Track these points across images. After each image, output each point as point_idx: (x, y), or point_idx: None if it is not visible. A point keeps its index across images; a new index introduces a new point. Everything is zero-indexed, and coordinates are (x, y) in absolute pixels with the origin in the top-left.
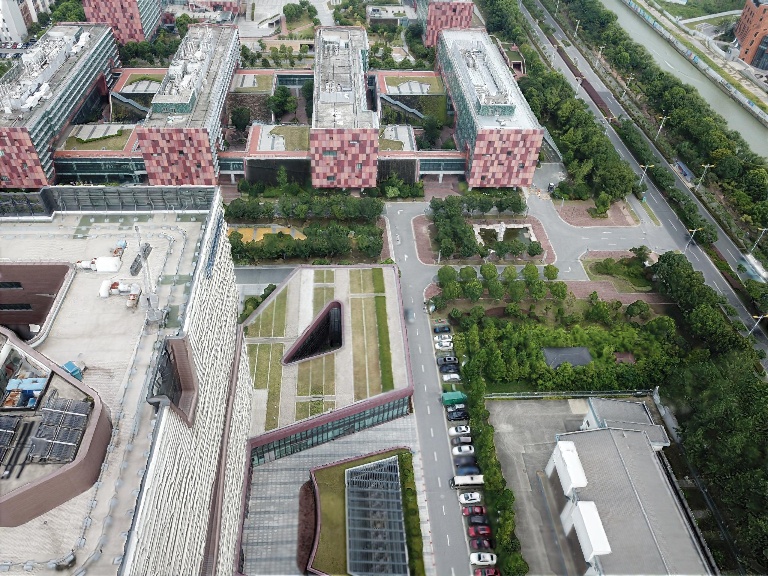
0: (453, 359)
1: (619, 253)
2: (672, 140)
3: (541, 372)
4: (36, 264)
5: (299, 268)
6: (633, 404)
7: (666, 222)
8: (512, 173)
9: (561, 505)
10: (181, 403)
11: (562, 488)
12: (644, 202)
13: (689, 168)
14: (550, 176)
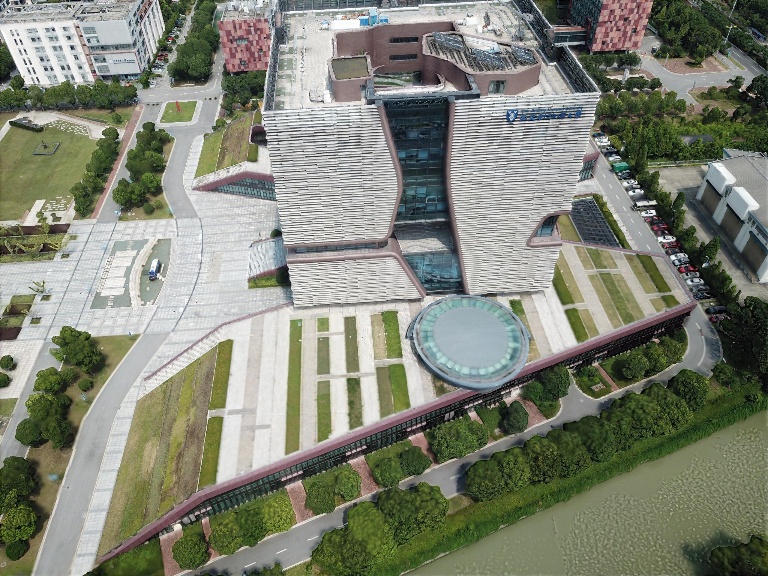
0: (613, 148)
1: (717, 87)
2: (744, 14)
3: (681, 147)
4: (432, 22)
5: None
6: (753, 153)
7: (749, 67)
8: (626, 37)
9: (713, 209)
10: None
11: (715, 194)
12: (729, 56)
13: (761, 33)
14: (650, 45)
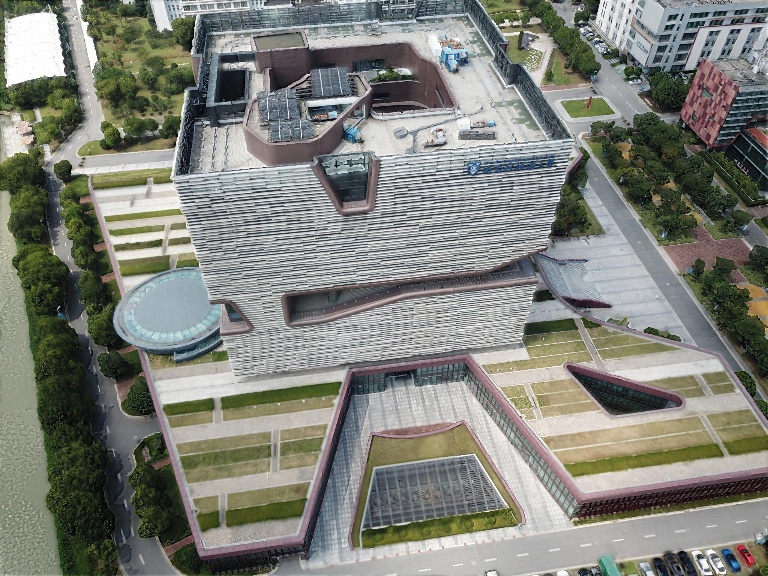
0: (681, 574)
1: None
2: None
3: None
4: (449, 94)
5: (717, 355)
6: None
7: None
8: None
9: None
10: (356, 202)
11: None
12: None
13: None
14: None
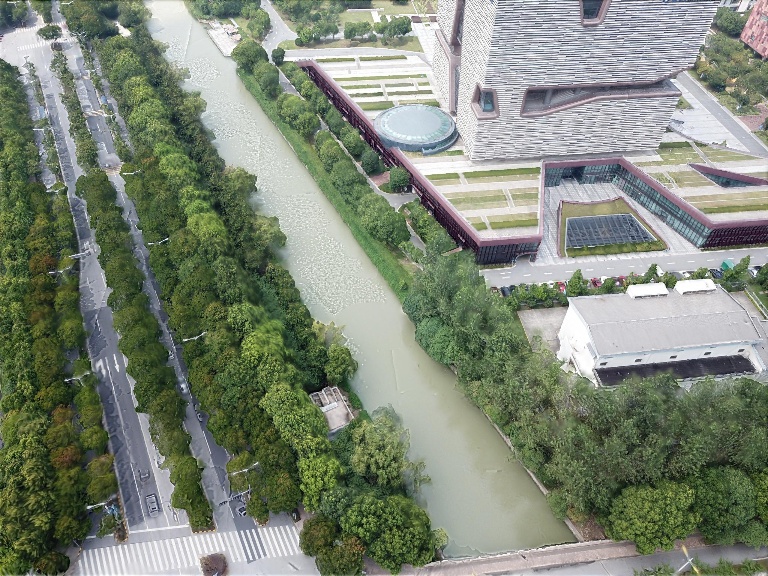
0: None
1: None
2: None
3: None
4: None
5: None
6: None
7: None
8: None
9: None
10: (591, 19)
11: None
12: None
13: None
14: None
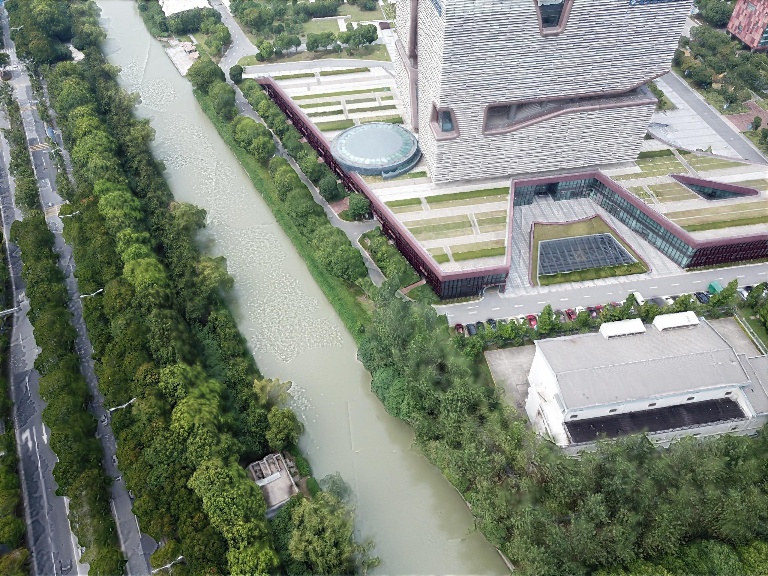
0: (766, 292)
1: None
2: None
3: None
4: None
5: None
6: None
7: None
8: None
9: None
10: (551, 28)
11: None
12: None
13: None
14: None
